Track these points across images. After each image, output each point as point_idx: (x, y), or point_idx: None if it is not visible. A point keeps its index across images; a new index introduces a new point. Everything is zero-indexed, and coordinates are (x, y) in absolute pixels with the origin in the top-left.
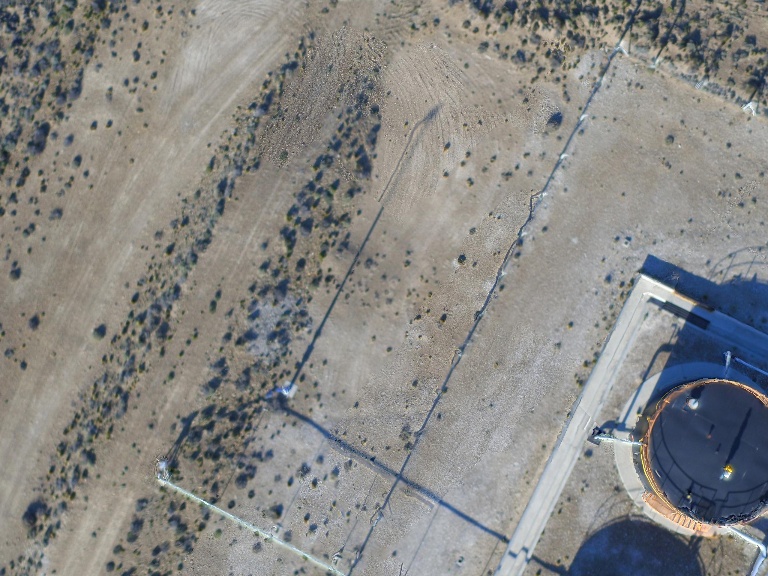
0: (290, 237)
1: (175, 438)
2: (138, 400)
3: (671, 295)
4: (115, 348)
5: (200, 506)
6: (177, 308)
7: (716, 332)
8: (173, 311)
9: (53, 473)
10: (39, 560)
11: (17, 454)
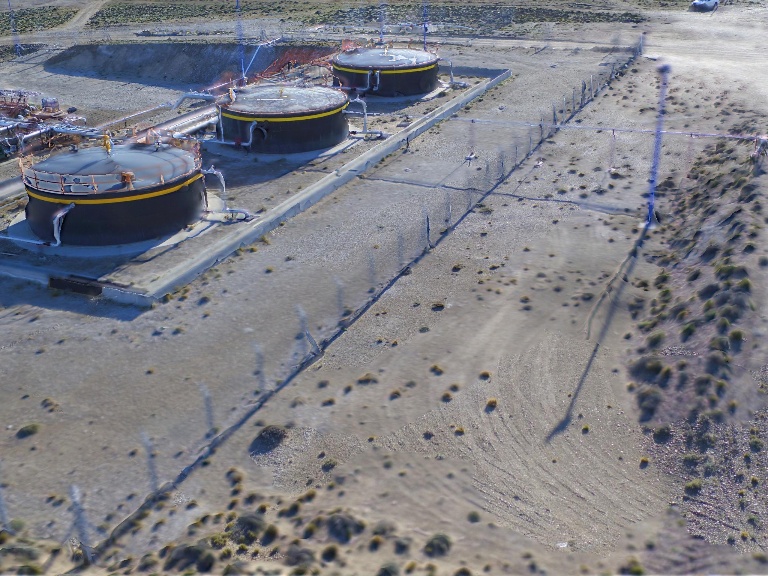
0: None
1: (765, 168)
2: None
3: None
4: None
5: None
6: None
7: (57, 277)
8: None
9: None
10: None
11: None
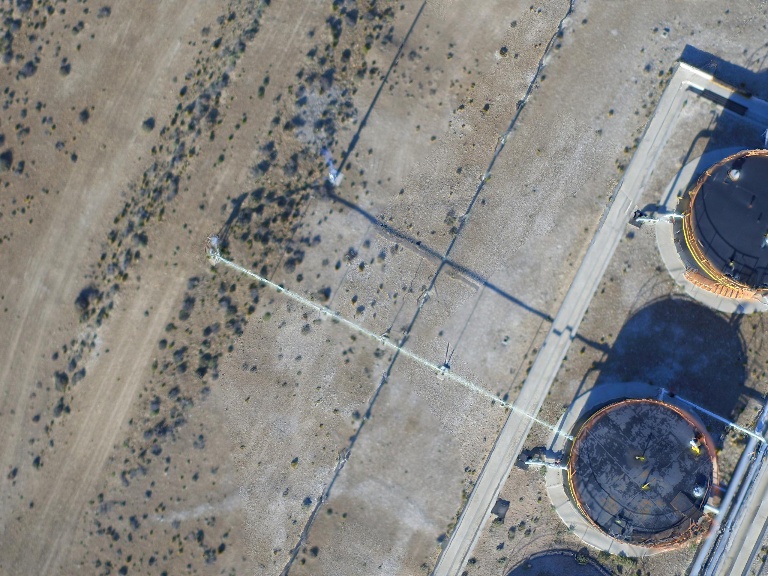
0: (336, 26)
1: (225, 219)
2: (189, 182)
3: (709, 83)
4: (164, 139)
5: (250, 289)
6: (226, 94)
7: (754, 118)
8: (222, 97)
9: (104, 260)
10: (92, 341)
11: (68, 243)
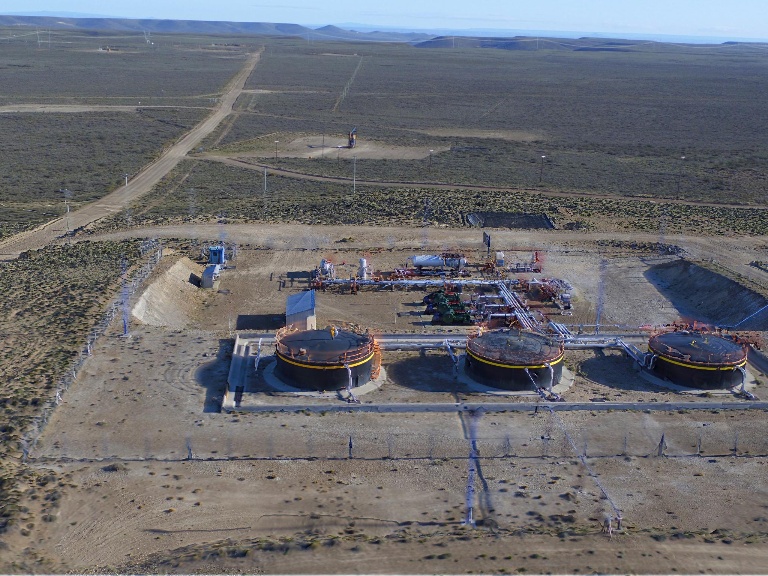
0: None
1: None
2: (581, 569)
3: (229, 400)
4: None
5: None
6: None
7: None
8: None
9: None
10: None
11: None
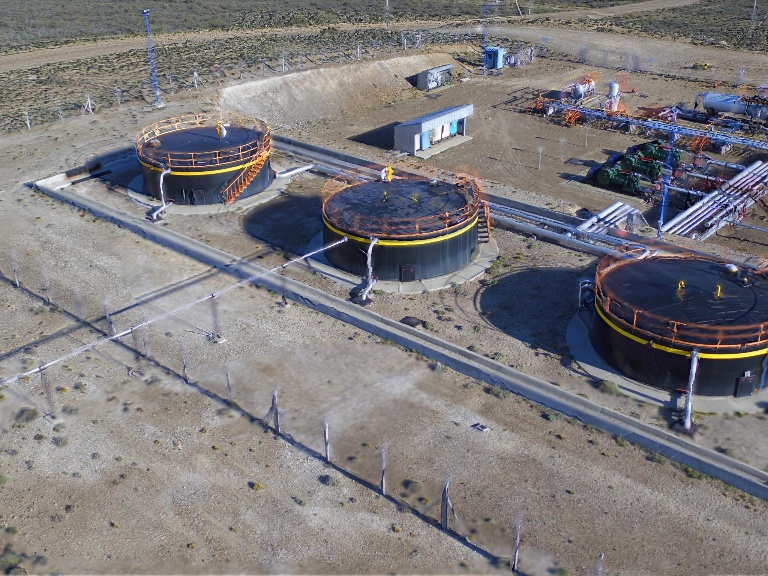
0: None
1: None
2: None
3: (69, 180)
4: None
5: None
6: None
7: None
8: None
9: None
10: None
11: None
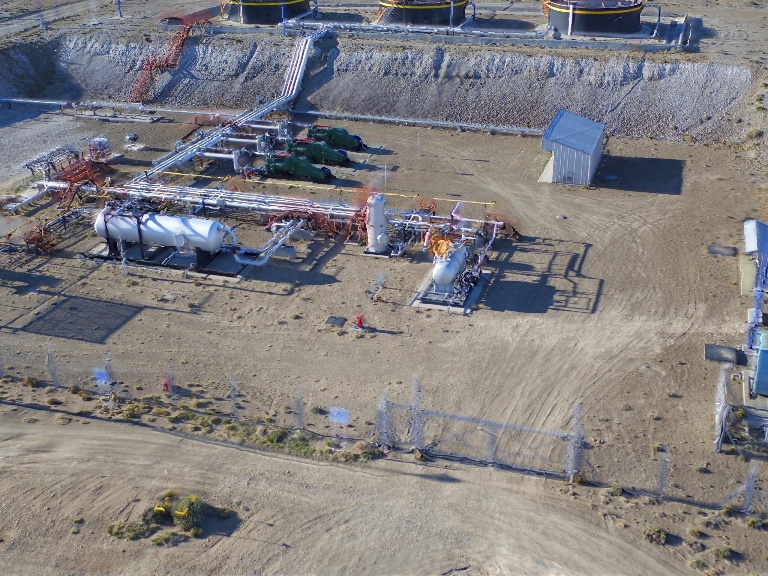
0: None
1: None
2: None
3: None
4: None
5: None
6: None
7: (672, 29)
8: None
9: None
10: None
11: None
